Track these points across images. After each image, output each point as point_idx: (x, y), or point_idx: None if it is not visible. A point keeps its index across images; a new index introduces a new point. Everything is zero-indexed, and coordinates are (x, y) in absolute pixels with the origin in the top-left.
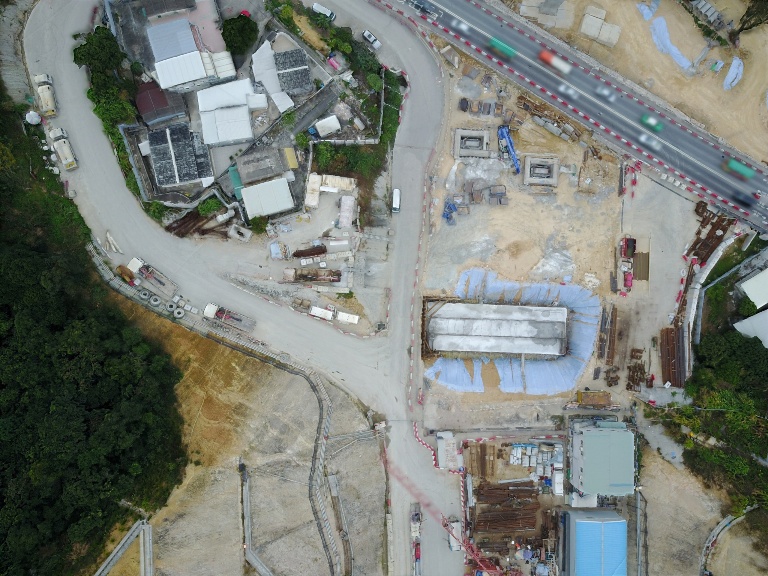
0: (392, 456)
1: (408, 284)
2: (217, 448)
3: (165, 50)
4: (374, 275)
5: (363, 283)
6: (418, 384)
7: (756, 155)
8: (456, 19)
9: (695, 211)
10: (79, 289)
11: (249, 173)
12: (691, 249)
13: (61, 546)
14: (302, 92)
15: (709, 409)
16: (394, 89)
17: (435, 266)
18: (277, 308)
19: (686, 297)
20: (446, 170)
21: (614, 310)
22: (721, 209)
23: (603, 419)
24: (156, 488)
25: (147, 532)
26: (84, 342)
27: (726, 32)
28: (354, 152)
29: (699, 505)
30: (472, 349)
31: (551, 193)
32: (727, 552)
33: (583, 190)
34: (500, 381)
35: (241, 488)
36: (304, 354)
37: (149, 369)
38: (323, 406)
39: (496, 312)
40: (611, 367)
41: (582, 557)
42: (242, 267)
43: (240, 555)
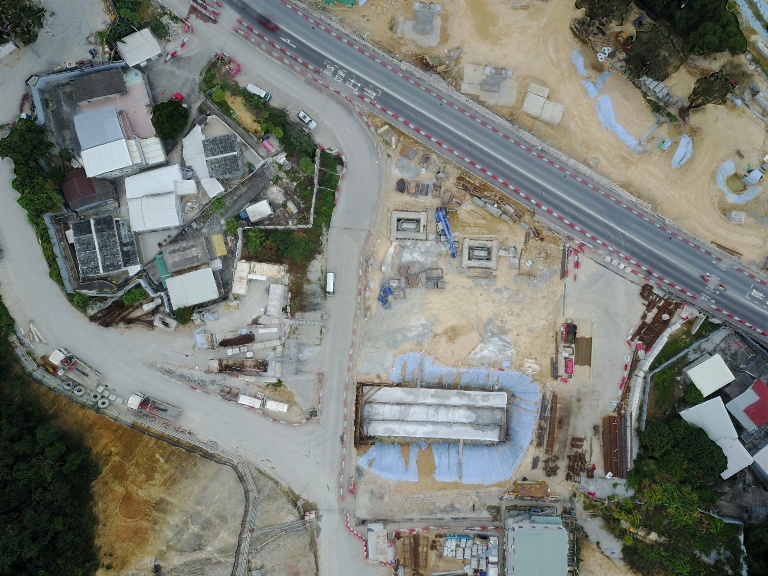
0: (323, 546)
1: (342, 369)
2: (132, 549)
3: (91, 138)
4: (307, 360)
5: (294, 370)
6: (350, 472)
7: (706, 236)
8: (394, 98)
9: (640, 295)
10: None
11: (175, 262)
12: (636, 334)
13: None
14: (233, 176)
15: (650, 503)
16: (330, 170)
17: (370, 351)
18: (205, 396)
19: (630, 384)
20: (382, 252)
21: (554, 397)
22: (667, 293)
23: (540, 512)
24: None
25: None
26: None
27: (676, 108)
28: (284, 238)
29: None
30: (409, 434)
31: (490, 276)
32: None
33: (524, 273)
34: (435, 469)
35: None
36: (233, 442)
37: (62, 470)
38: (250, 497)
39: (434, 397)
40: (550, 456)
41: None
42: (168, 356)
43: None
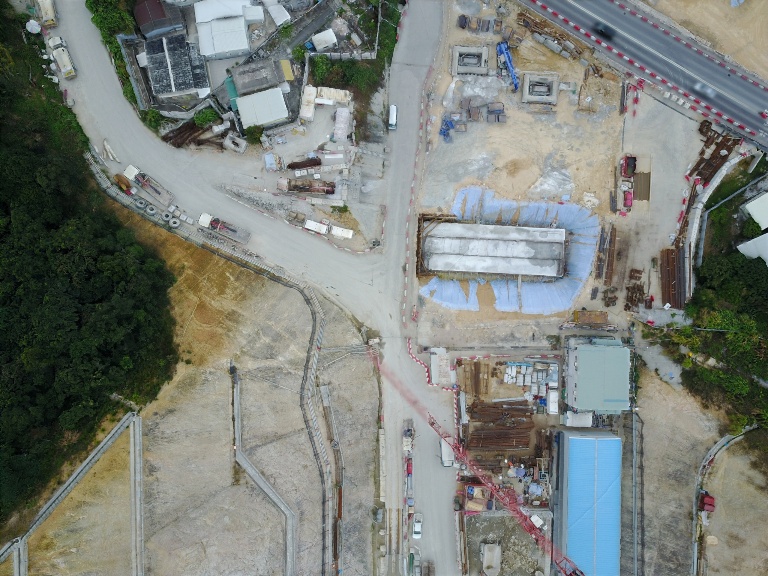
0: (386, 372)
1: (404, 202)
2: (208, 350)
3: None
4: (370, 192)
5: (358, 198)
6: (412, 301)
7: (764, 74)
8: None
9: (699, 130)
10: (76, 194)
11: (244, 83)
12: (694, 169)
13: (53, 433)
14: (299, 6)
15: (709, 330)
16: (392, 6)
17: (431, 184)
18: (272, 221)
19: (688, 218)
20: (443, 87)
21: (613, 230)
22: (726, 128)
23: (600, 338)
24: (147, 383)
25: (137, 423)
26: (78, 237)
27: None
28: (350, 65)
29: (697, 425)
30: (468, 269)
31: (550, 111)
32: (724, 471)
33: (583, 108)
34: (496, 300)
35: (232, 390)
36: (298, 268)
37: (142, 268)
38: (316, 318)
39: (493, 232)
40: (609, 287)
41: (575, 474)
42: (237, 178)
43: (230, 456)
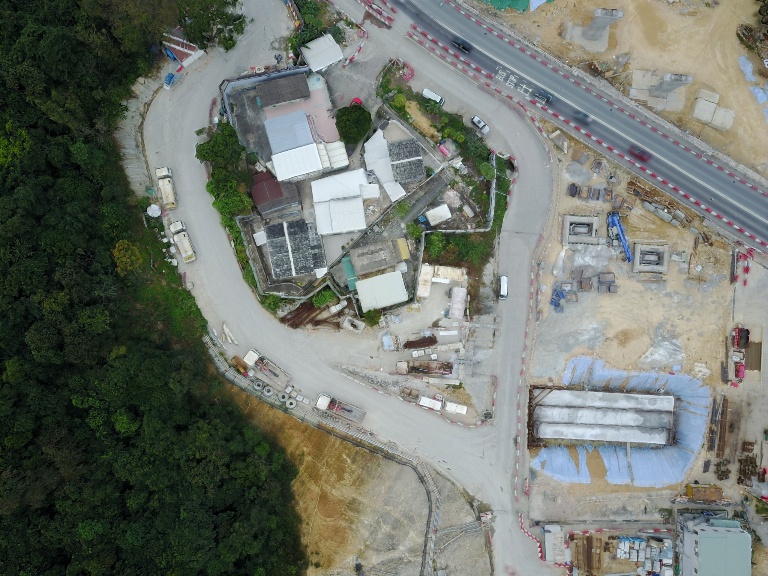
0: (497, 547)
1: (514, 372)
2: (335, 548)
3: (282, 142)
4: None
5: (471, 372)
6: (524, 474)
7: None
8: (565, 103)
9: None
10: None
11: (363, 265)
12: None
13: None
14: (413, 180)
15: None
16: (502, 174)
17: (542, 354)
18: (386, 398)
19: None
20: (554, 256)
21: (725, 401)
22: None
23: (714, 515)
24: None
25: None
26: (212, 445)
27: None
28: (465, 242)
29: None
30: (577, 437)
31: (660, 280)
32: None
33: (693, 277)
34: (607, 472)
35: None
36: (411, 443)
37: (271, 470)
38: (431, 498)
39: (601, 400)
40: (722, 460)
41: None
42: (353, 358)
43: None
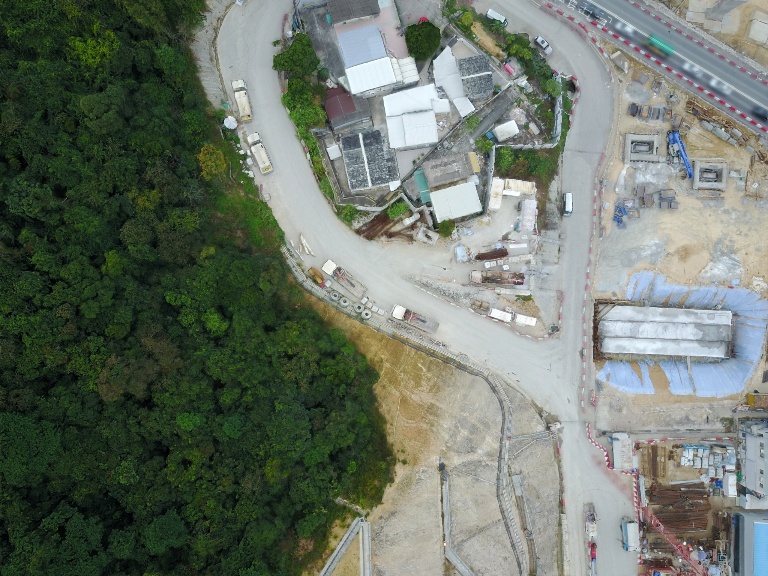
0: (565, 457)
1: (579, 287)
2: (419, 447)
3: (356, 56)
4: (546, 278)
5: None
6: (590, 386)
7: None
8: (625, 25)
9: None
10: None
11: (437, 177)
12: None
13: None
14: (480, 97)
15: None
16: (565, 94)
17: (605, 269)
18: (457, 310)
19: None
20: (616, 174)
21: None
22: None
23: None
24: (370, 486)
25: (366, 529)
26: (302, 342)
27: None
28: (534, 156)
29: None
30: (638, 351)
31: (718, 197)
32: None
33: (750, 194)
34: (669, 383)
35: (441, 487)
36: (481, 355)
37: (358, 369)
38: (504, 407)
39: (662, 315)
40: None
41: (761, 558)
42: (427, 269)
43: (440, 553)
